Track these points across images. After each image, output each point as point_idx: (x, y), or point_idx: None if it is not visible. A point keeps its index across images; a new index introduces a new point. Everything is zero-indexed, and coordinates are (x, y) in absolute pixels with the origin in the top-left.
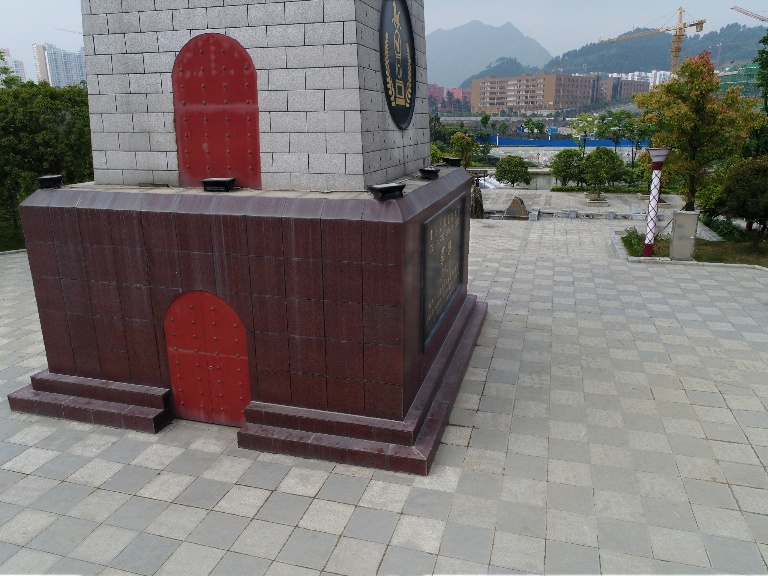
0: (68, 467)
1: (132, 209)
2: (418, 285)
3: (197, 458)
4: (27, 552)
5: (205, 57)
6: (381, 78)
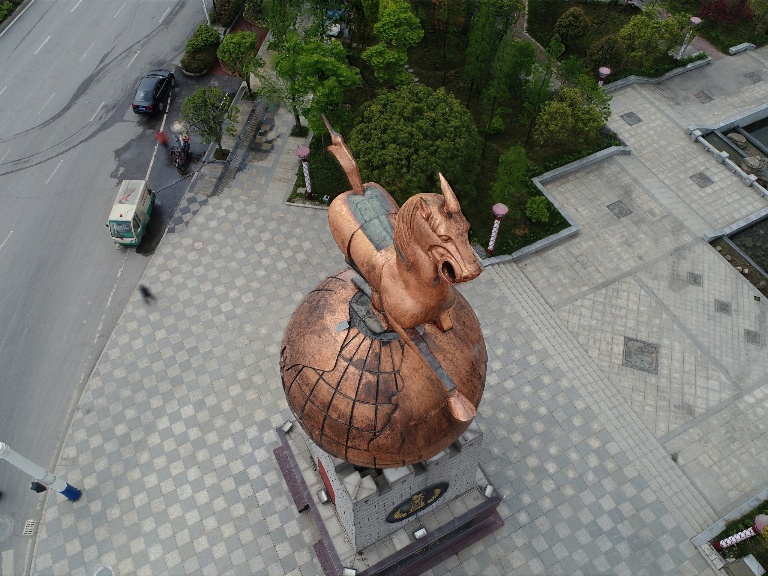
0: (269, 512)
1: (297, 477)
2: None
3: (300, 541)
4: (242, 550)
5: (324, 470)
6: None
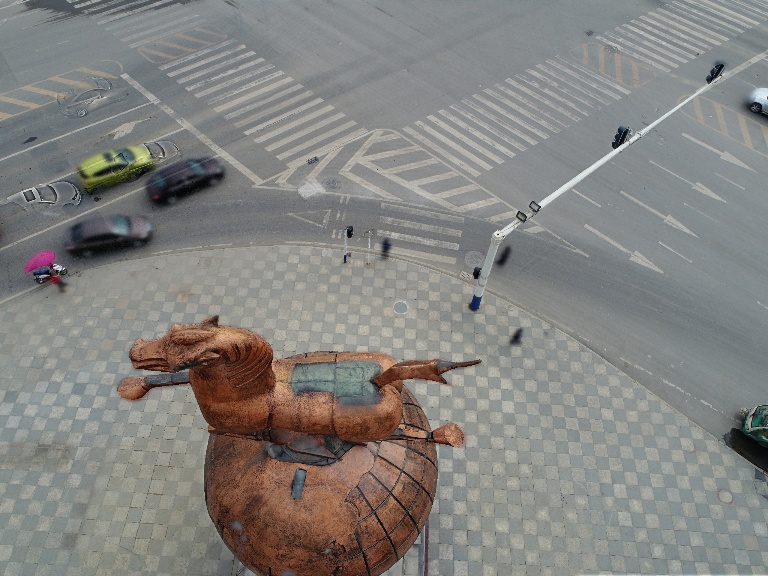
0: None
1: None
2: None
3: None
4: None
5: None
6: None
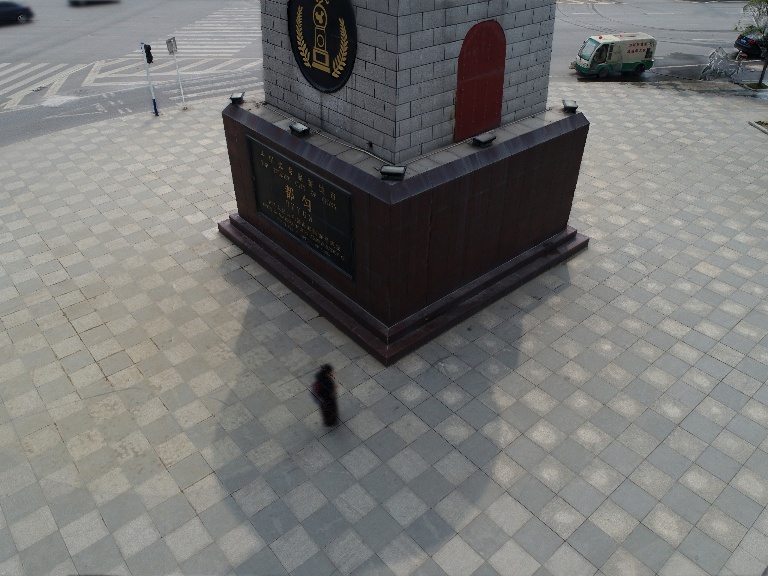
0: None
1: None
2: (246, 165)
3: None
4: None
5: None
6: (289, 40)
